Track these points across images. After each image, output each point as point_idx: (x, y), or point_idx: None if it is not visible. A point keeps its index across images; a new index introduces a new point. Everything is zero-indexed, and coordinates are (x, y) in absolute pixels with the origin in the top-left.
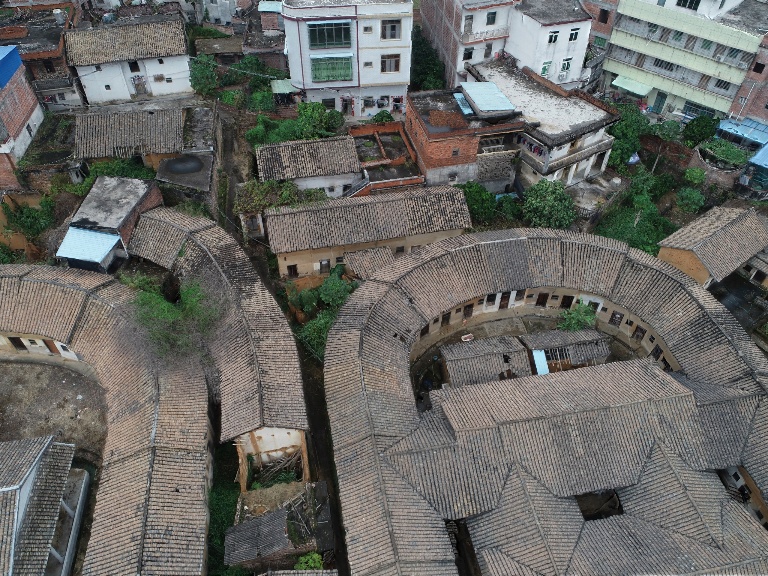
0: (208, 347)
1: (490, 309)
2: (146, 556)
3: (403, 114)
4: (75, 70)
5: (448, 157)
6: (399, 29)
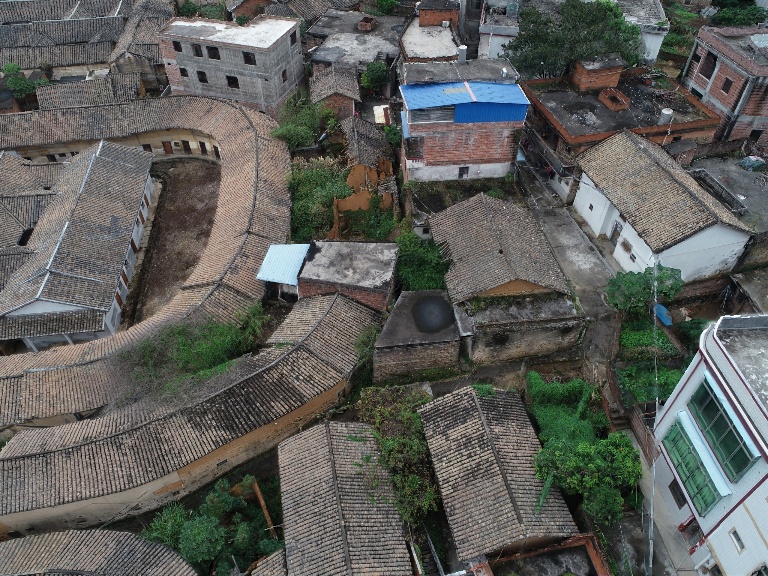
0: (141, 399)
1: None
2: None
3: None
4: None
5: None
6: None
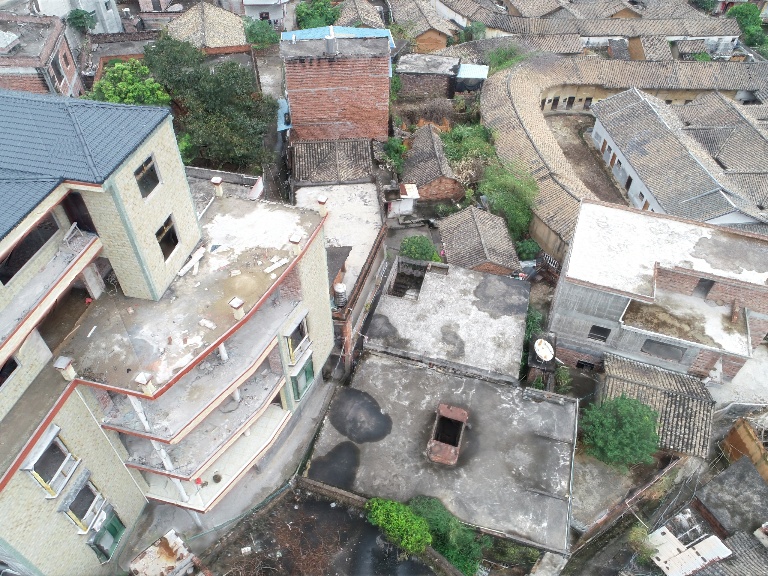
0: None
1: None
2: None
3: (288, 3)
4: None
5: None
6: None
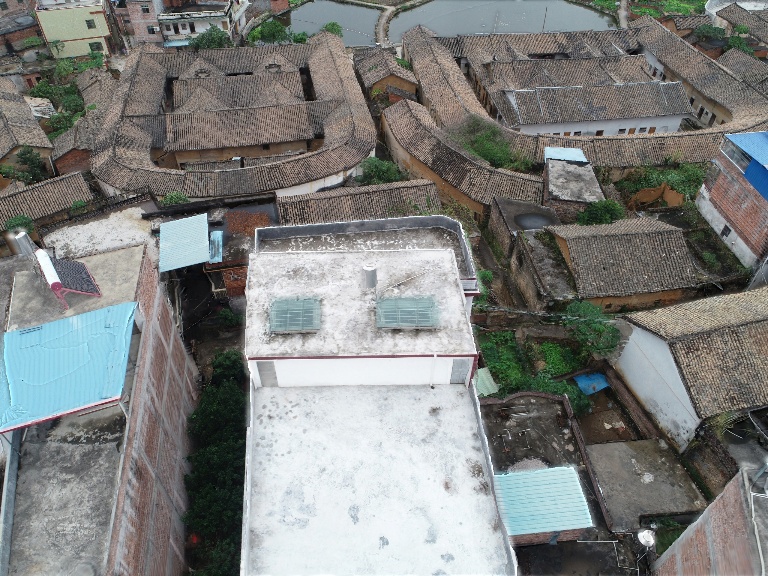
0: None
1: None
2: None
3: None
4: None
5: None
6: None
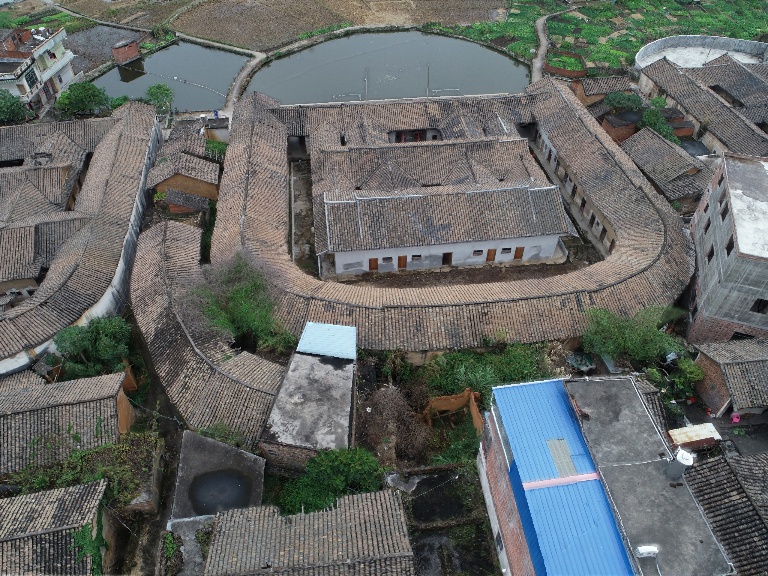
0: None
1: None
2: None
3: None
4: None
5: None
6: None
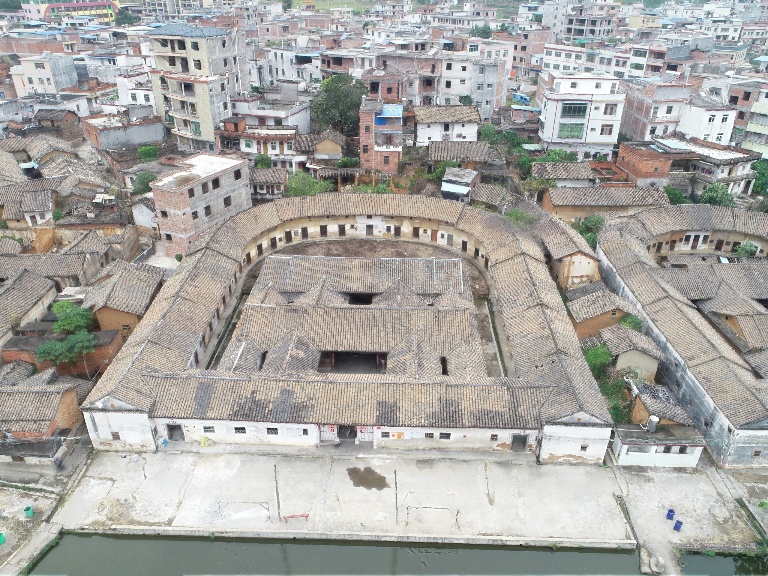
0: None
1: (685, 248)
2: (536, 283)
3: None
4: (416, 126)
5: (651, 172)
6: (615, 110)
